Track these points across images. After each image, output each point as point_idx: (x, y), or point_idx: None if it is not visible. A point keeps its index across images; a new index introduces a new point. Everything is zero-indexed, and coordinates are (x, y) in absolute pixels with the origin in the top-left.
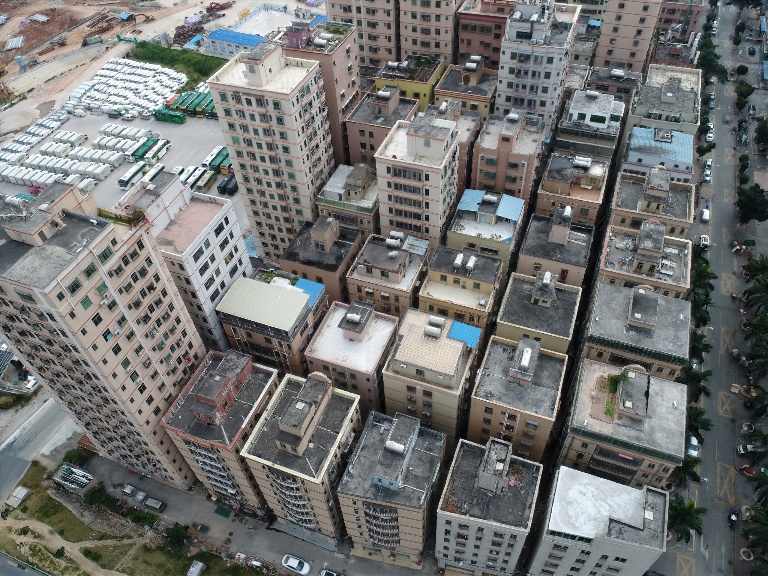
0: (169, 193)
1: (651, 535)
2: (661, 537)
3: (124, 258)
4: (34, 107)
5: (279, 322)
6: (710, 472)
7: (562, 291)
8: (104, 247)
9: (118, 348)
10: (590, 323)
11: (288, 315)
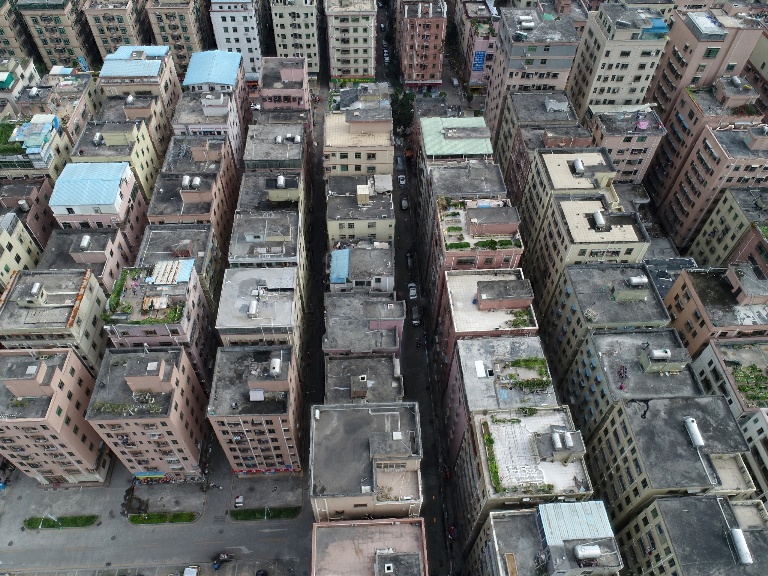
0: None
1: None
2: None
3: None
4: None
5: None
6: None
7: None
8: None
9: None
10: None
11: None
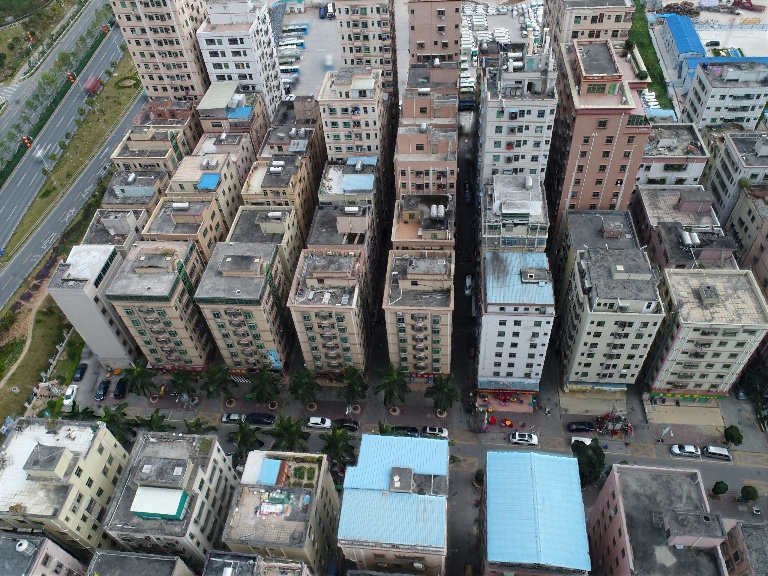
0: (236, 7)
1: (58, 283)
2: (55, 287)
3: (152, 2)
4: None
5: (203, 104)
6: (210, 432)
7: (282, 238)
8: None
9: (139, 43)
10: (229, 242)
11: (208, 105)
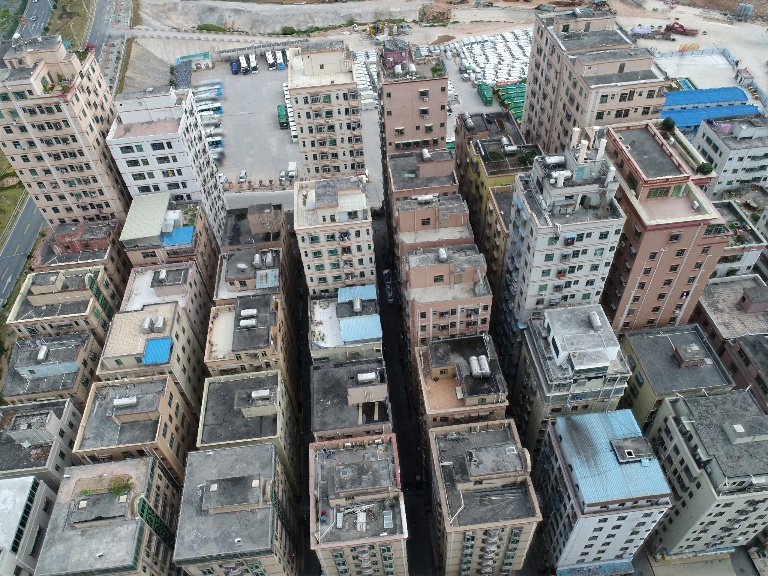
0: (155, 101)
1: None
2: None
3: (40, 108)
4: (439, 35)
5: (127, 232)
6: None
7: (274, 422)
8: (19, 90)
9: (27, 159)
10: None
11: (135, 233)
